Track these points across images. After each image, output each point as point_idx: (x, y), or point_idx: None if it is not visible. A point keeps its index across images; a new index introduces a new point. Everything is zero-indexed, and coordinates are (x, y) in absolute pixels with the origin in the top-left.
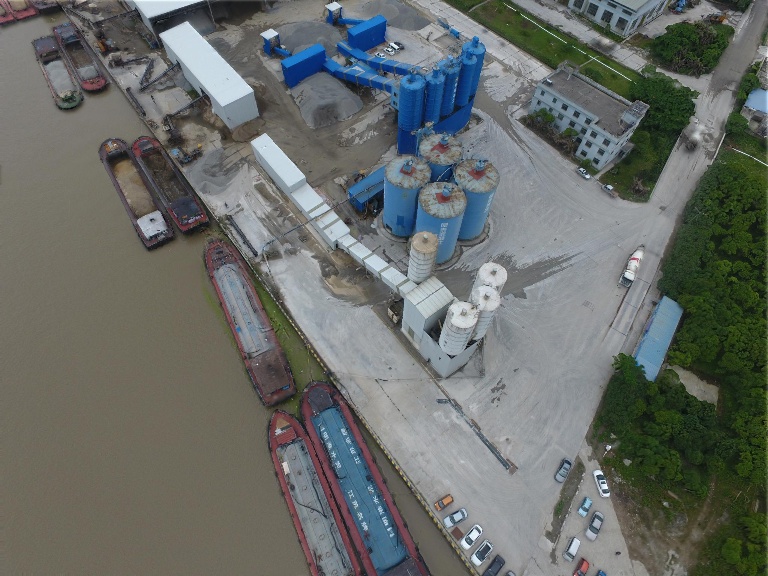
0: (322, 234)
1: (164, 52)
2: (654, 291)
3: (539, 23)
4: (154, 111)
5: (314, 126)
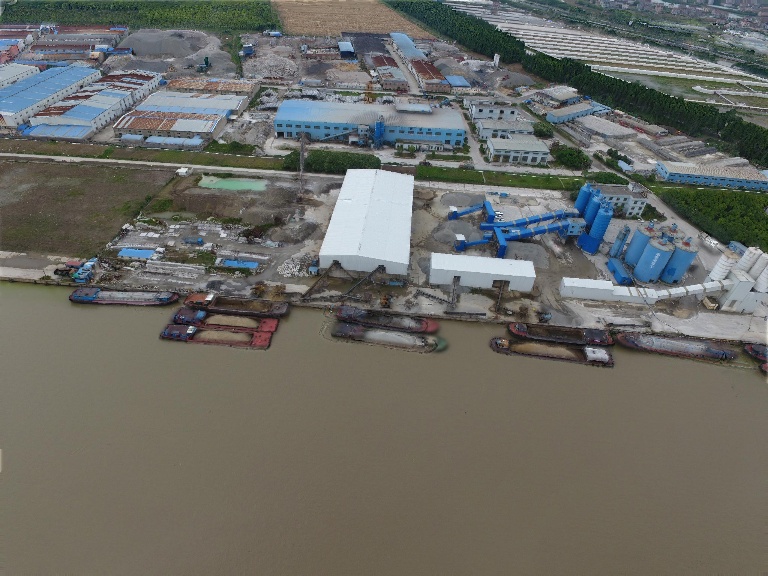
0: (643, 301)
1: (412, 284)
2: (720, 244)
3: (517, 174)
4: (479, 312)
5: (546, 267)
